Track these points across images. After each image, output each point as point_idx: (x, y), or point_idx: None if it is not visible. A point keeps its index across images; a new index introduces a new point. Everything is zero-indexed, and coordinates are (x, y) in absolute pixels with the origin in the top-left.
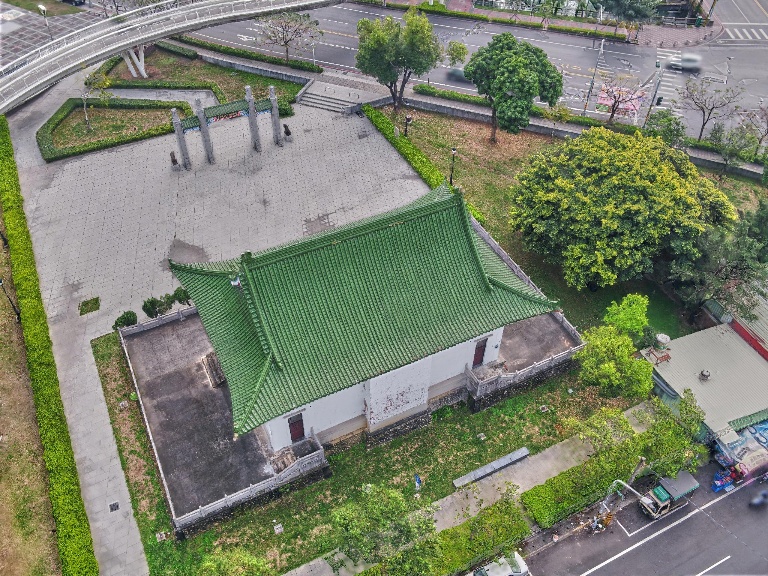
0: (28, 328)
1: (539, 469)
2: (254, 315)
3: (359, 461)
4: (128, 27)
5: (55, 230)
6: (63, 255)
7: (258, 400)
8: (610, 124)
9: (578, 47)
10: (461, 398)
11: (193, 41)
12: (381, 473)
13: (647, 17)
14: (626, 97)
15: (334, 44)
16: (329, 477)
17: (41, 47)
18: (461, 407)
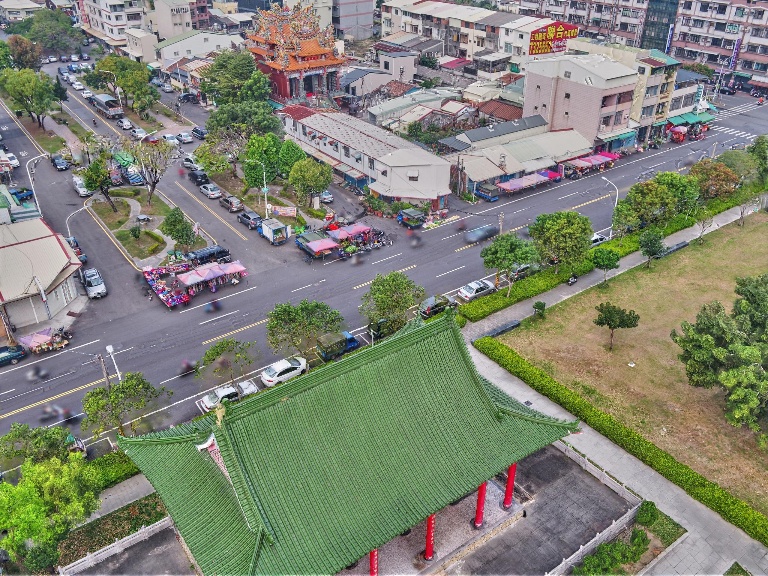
0: (764, 519)
1: None
2: None
3: None
4: None
5: None
6: None
7: None
8: None
9: None
10: None
11: None
12: None
13: None
14: None
15: None
16: None
17: None
18: None
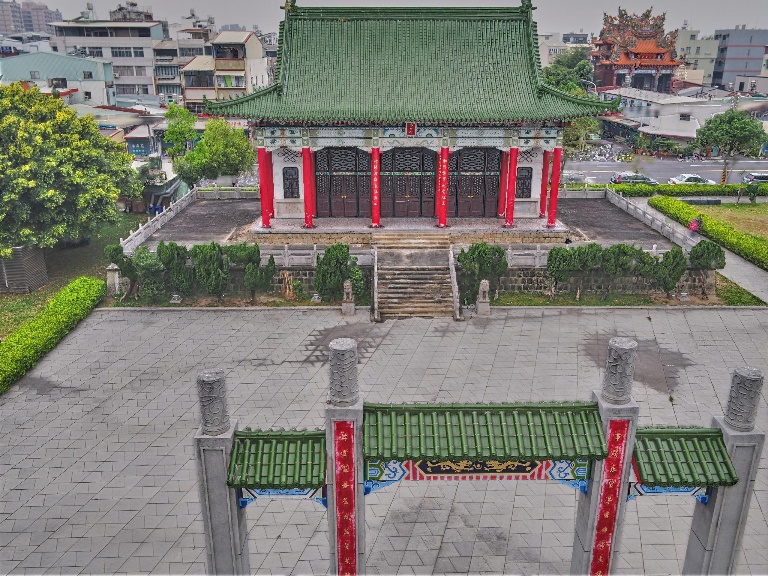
0: None
1: None
2: None
3: None
4: None
5: None
6: None
7: None
8: None
9: None
10: None
11: None
12: None
13: None
14: None
15: None
16: None
17: None
18: None
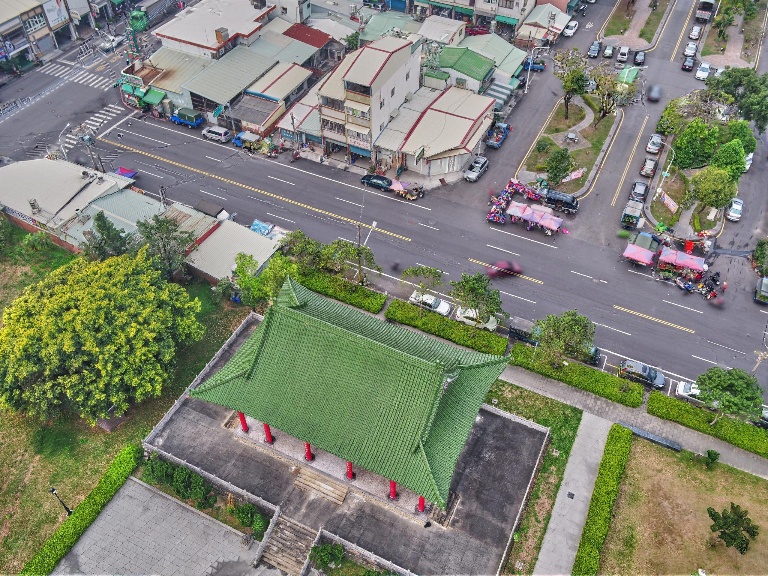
0: None
1: None
2: None
3: None
4: None
5: None
6: None
7: None
8: None
9: None
10: None
11: None
12: None
13: None
14: None
15: None
16: None
17: None
18: None
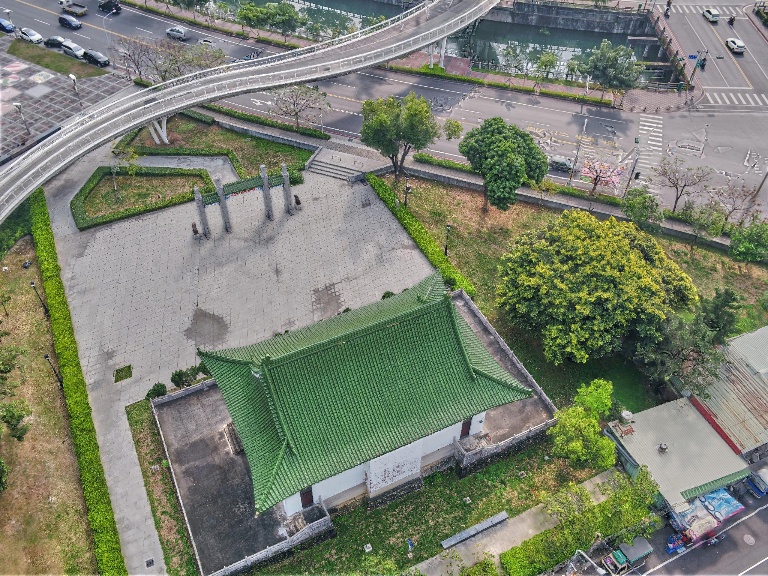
0: (70, 396)
1: (516, 531)
2: (272, 407)
3: (360, 522)
4: (153, 102)
5: (90, 299)
6: (98, 323)
7: (275, 481)
8: (593, 195)
9: (567, 112)
10: (450, 464)
11: (210, 106)
12: (379, 534)
13: (631, 87)
14: (607, 171)
15: (341, 109)
16: (334, 537)
17: (74, 122)
18: (450, 472)
